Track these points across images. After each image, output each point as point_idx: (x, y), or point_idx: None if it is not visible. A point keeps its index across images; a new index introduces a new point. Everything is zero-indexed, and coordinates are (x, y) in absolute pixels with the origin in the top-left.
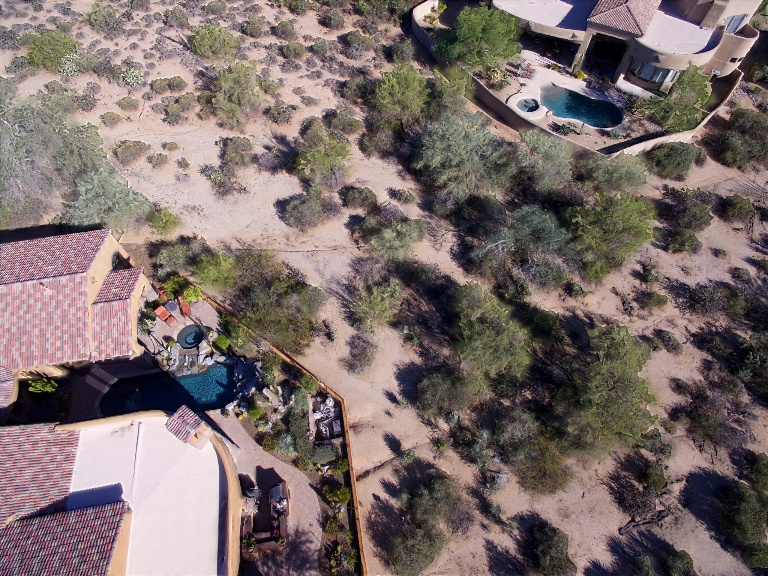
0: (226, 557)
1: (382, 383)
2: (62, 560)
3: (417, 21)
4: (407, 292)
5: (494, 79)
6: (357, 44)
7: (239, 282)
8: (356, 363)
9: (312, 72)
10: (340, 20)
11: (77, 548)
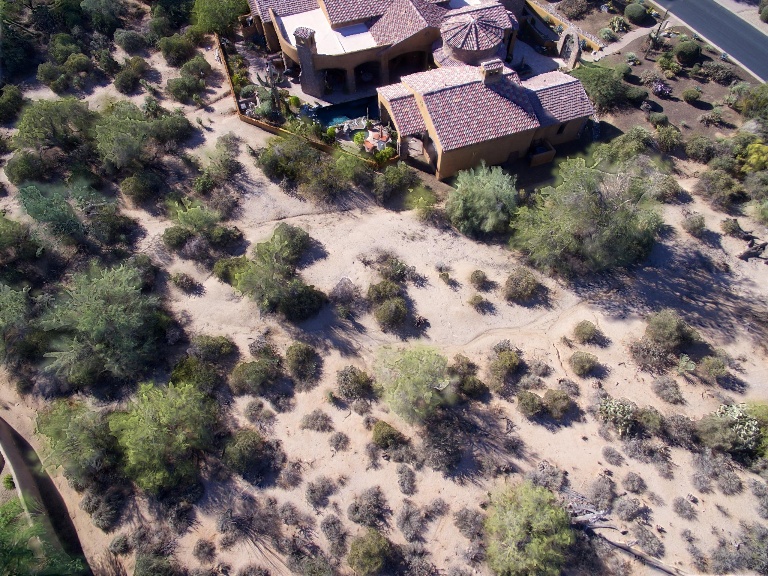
0: (280, 25)
1: (216, 135)
2: (347, 0)
3: None
4: (192, 193)
5: None
6: None
7: (333, 166)
8: (234, 142)
9: (328, 503)
10: None
11: (344, 5)
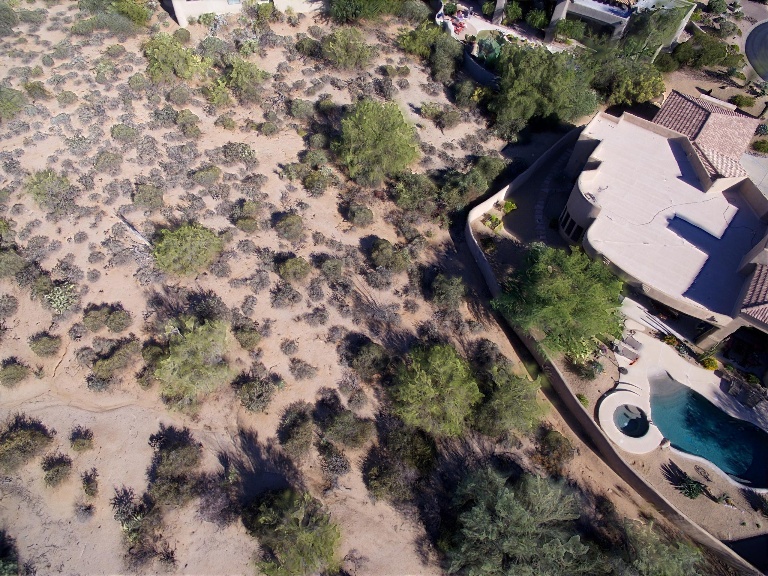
0: None
1: None
2: None
3: (473, 222)
4: None
5: (579, 358)
6: (384, 265)
7: None
8: None
9: (314, 309)
10: (366, 217)
11: None
